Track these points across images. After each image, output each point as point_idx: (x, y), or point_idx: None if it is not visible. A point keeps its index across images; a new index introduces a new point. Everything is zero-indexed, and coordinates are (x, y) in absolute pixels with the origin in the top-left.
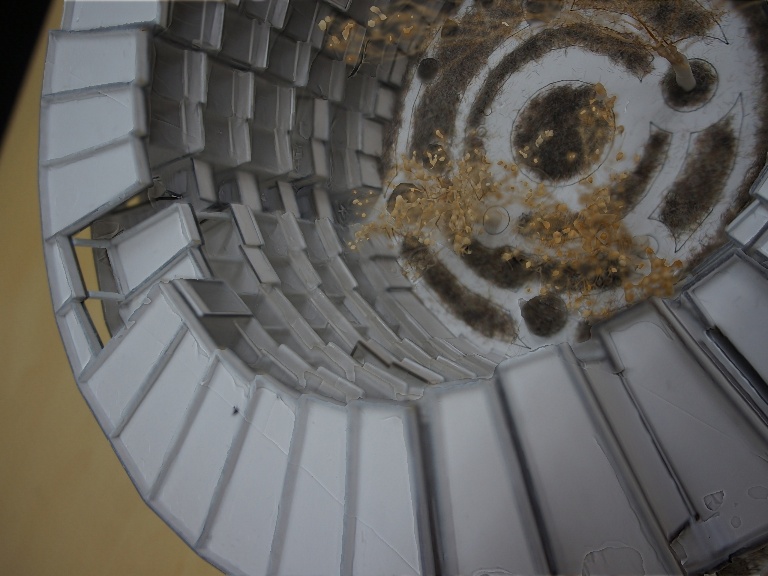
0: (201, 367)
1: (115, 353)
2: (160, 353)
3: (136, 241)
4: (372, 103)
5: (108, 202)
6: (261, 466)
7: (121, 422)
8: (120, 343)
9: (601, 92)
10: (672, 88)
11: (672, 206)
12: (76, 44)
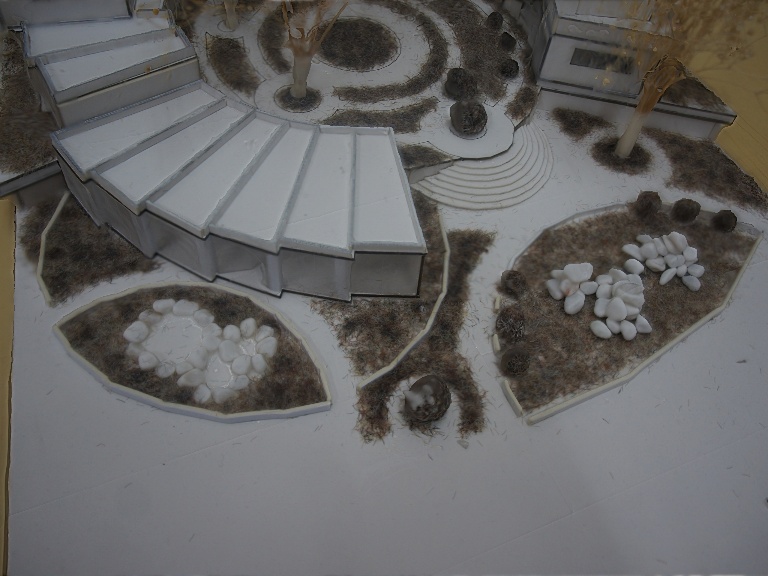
0: None
1: None
2: None
3: None
4: None
5: None
6: None
7: None
8: None
9: None
10: None
11: (234, 45)
12: None
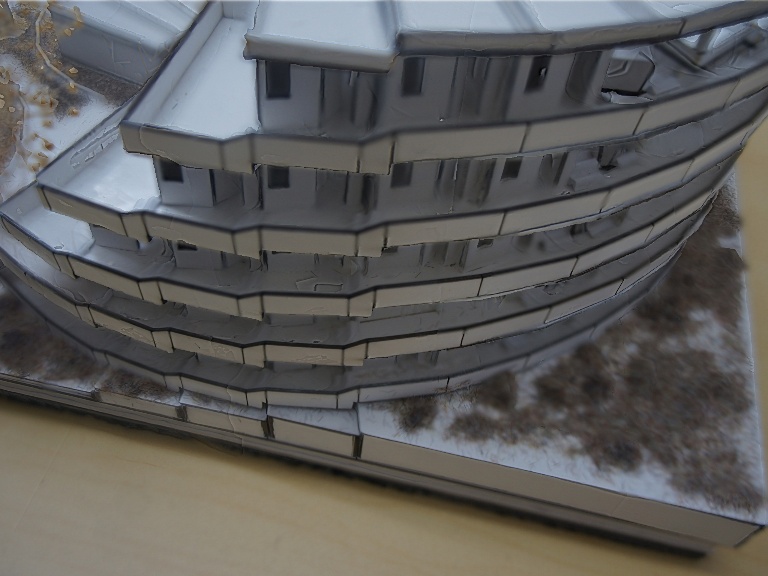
0: None
1: None
2: None
3: None
4: None
5: None
6: None
7: None
8: None
9: None
10: None
11: None
12: (416, 3)
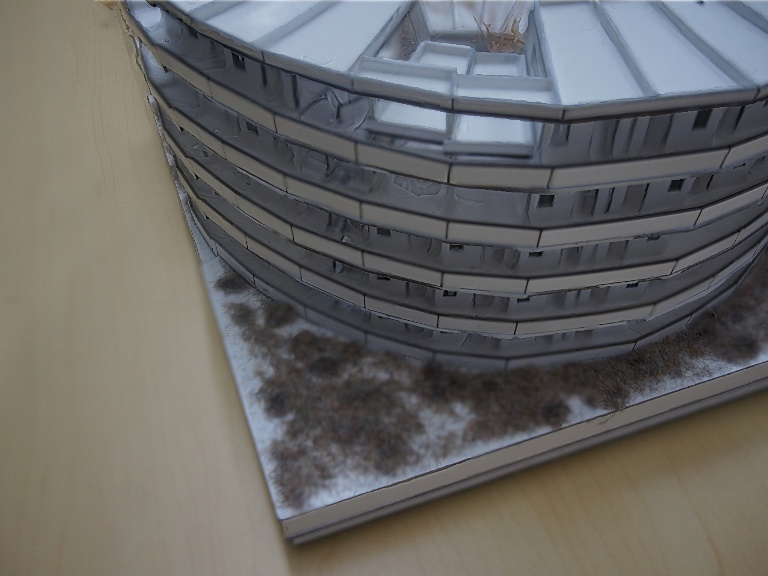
0: (644, 4)
1: (558, 71)
2: (604, 22)
3: (398, 104)
4: None
5: (399, 8)
6: (762, 4)
7: (644, 94)
8: (552, 62)
9: (517, 31)
10: None
11: None
12: None
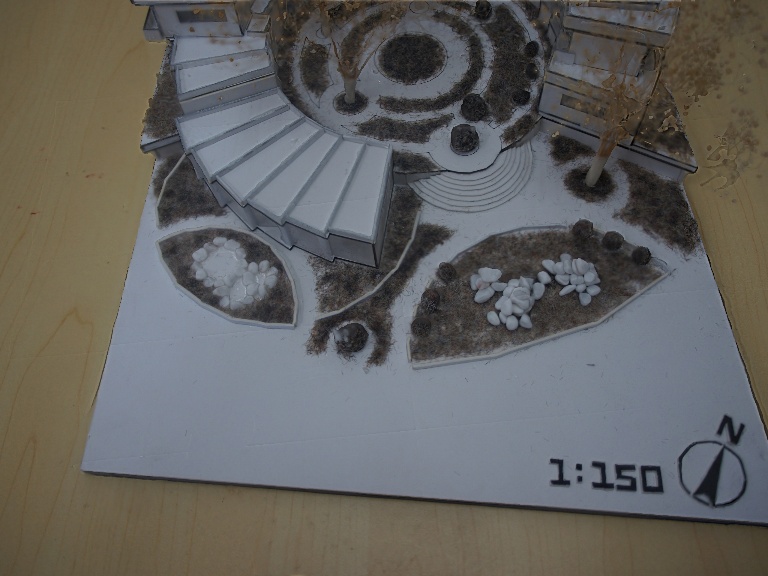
0: None
1: None
2: None
3: None
4: (547, 2)
5: None
6: None
7: None
8: None
9: None
10: (358, 96)
11: (321, 51)
12: None
